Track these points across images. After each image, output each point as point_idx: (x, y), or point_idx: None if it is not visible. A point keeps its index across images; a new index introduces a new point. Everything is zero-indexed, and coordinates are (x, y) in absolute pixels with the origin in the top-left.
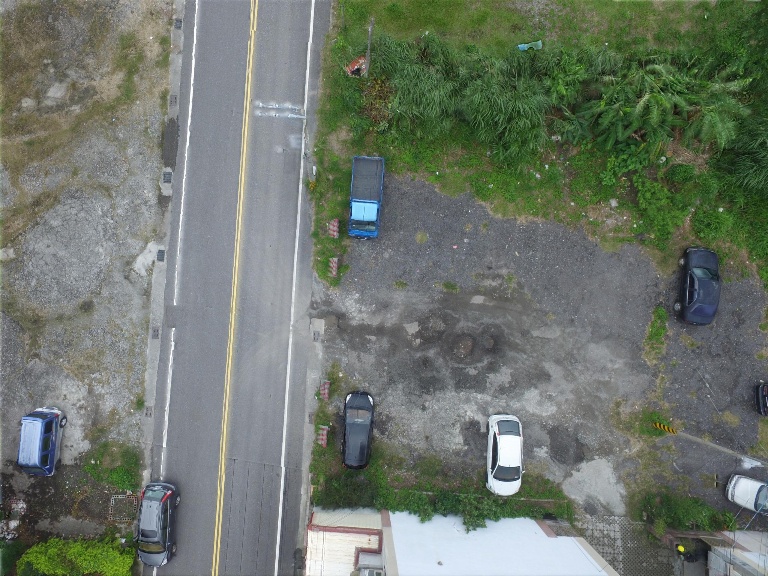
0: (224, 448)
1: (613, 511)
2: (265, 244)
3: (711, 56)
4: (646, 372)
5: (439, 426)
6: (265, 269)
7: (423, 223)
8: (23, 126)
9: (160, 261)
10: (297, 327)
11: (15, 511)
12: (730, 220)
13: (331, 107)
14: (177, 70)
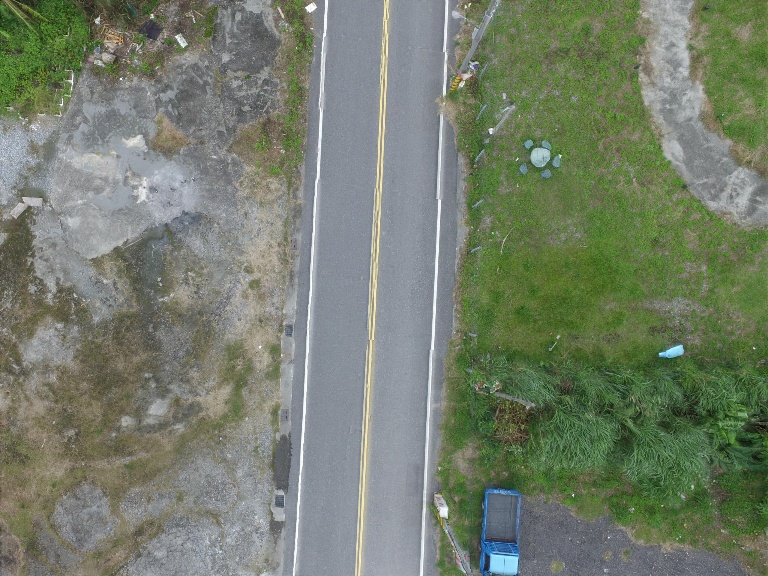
0: None
1: None
2: (387, 575)
3: None
4: None
5: None
6: None
7: (558, 550)
8: (123, 447)
9: None
10: None
11: None
12: None
13: (456, 422)
14: (288, 381)
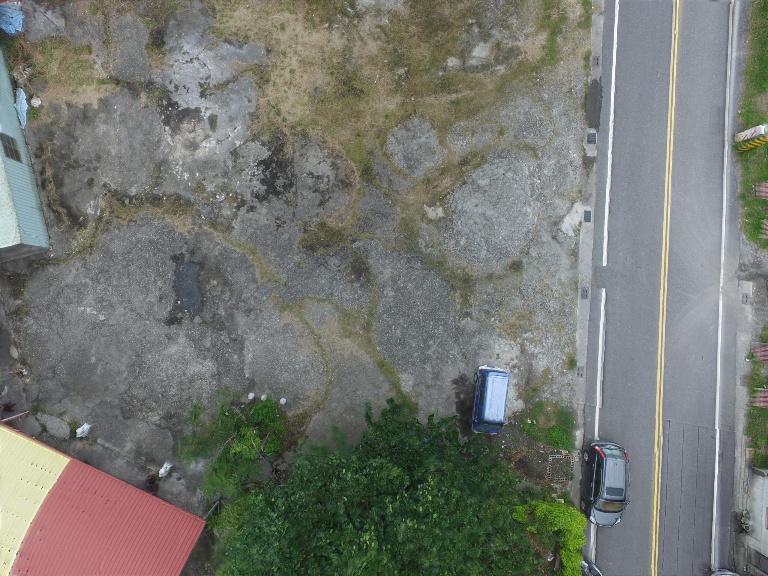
0: (661, 409)
1: None
2: (693, 205)
3: None
4: None
5: None
6: (694, 230)
7: None
8: (449, 85)
9: (586, 221)
10: (726, 289)
11: None
12: None
13: (756, 69)
14: (599, 31)
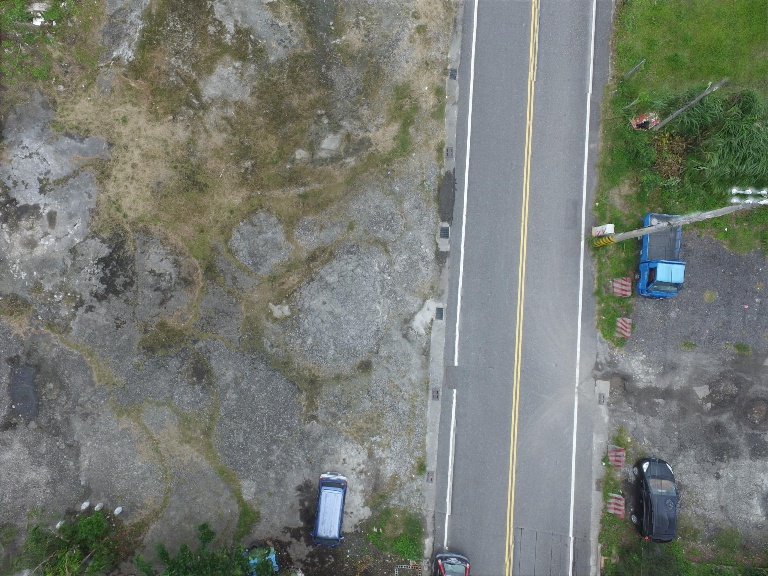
0: (512, 517)
1: None
2: (548, 302)
3: None
4: None
5: (734, 495)
6: (548, 328)
7: (712, 281)
8: (297, 179)
9: (438, 319)
10: (582, 389)
11: None
12: None
13: (614, 160)
14: (453, 121)
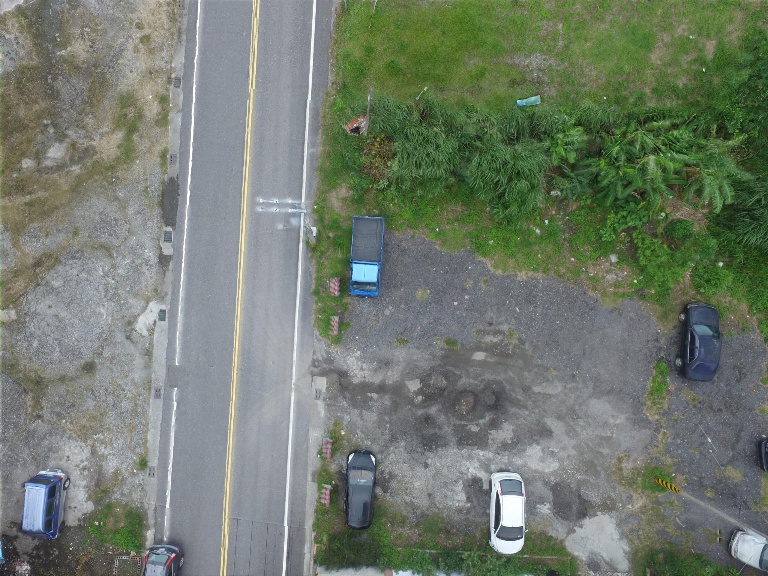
0: (227, 508)
1: (616, 567)
2: (266, 302)
3: (710, 114)
4: (648, 427)
5: (442, 483)
6: (266, 328)
7: (424, 280)
8: (23, 187)
9: (161, 320)
10: (299, 385)
11: (19, 573)
12: (730, 275)
13: (330, 164)
14: (176, 129)
